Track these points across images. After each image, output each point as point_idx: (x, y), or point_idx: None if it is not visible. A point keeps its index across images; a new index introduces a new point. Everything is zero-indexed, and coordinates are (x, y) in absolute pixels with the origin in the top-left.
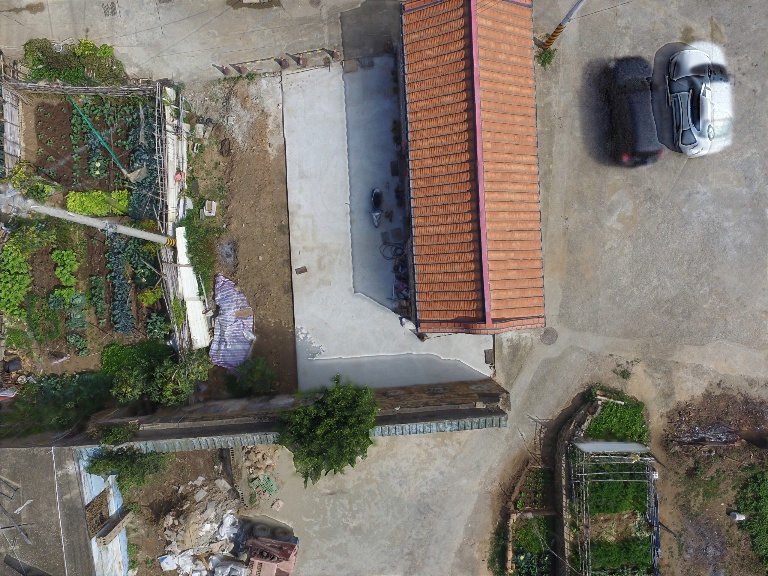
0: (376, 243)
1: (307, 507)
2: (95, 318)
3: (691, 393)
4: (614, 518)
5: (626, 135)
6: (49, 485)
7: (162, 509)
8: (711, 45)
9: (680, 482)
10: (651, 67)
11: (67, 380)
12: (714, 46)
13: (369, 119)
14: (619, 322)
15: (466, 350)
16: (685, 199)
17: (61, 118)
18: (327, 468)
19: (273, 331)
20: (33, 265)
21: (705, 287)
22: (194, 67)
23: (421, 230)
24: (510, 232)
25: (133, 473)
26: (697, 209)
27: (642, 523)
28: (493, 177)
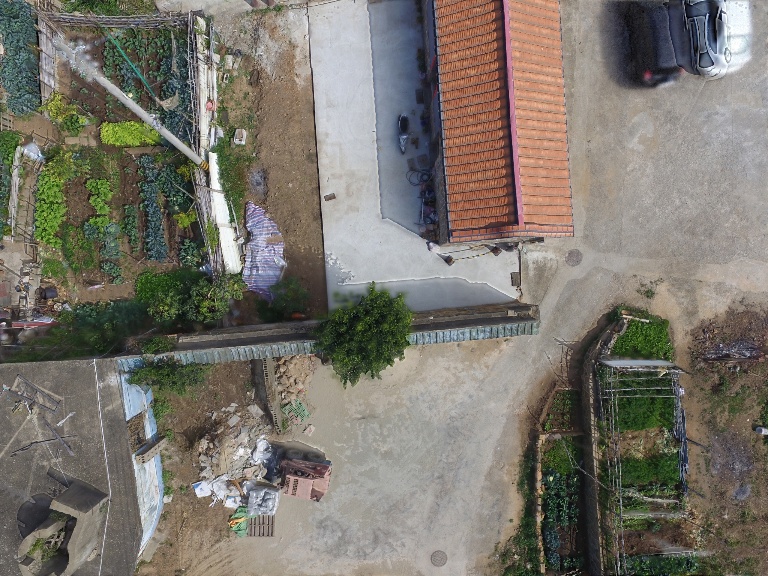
0: (403, 170)
1: (339, 432)
2: (128, 247)
3: (714, 311)
4: (642, 436)
5: (645, 59)
6: (91, 397)
7: (197, 434)
8: None
9: (706, 399)
10: None
11: (102, 308)
12: None
13: (394, 48)
14: (642, 242)
15: (493, 273)
16: (704, 120)
17: (93, 51)
18: (366, 368)
19: (303, 257)
20: (67, 195)
21: (726, 207)
22: None
23: (451, 141)
24: (539, 140)
25: (174, 382)
26: (716, 130)
27: (670, 439)
28: (522, 85)
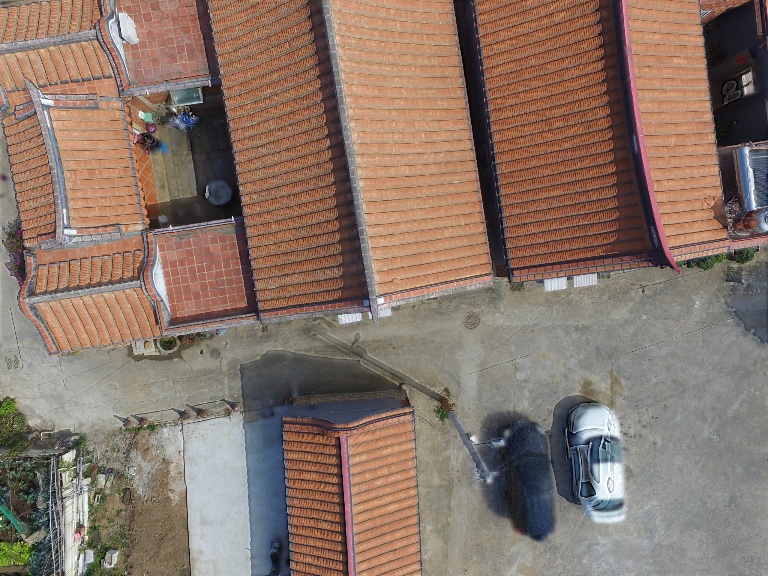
0: None
1: None
2: None
3: None
4: None
5: (525, 487)
6: None
7: None
8: (611, 398)
9: None
10: (550, 420)
11: None
12: (614, 399)
13: (270, 466)
14: None
15: None
16: (585, 550)
17: None
18: None
19: None
20: None
21: None
22: (96, 418)
23: None
24: None
25: None
26: (597, 560)
27: None
28: None
